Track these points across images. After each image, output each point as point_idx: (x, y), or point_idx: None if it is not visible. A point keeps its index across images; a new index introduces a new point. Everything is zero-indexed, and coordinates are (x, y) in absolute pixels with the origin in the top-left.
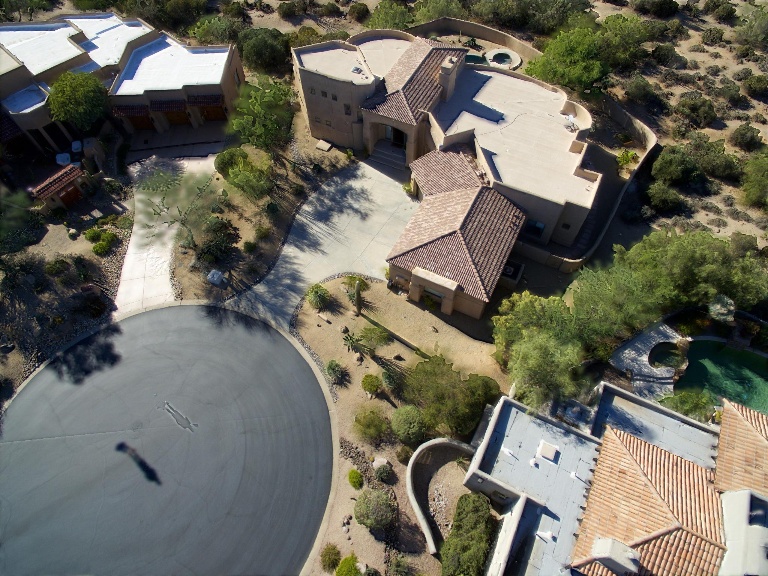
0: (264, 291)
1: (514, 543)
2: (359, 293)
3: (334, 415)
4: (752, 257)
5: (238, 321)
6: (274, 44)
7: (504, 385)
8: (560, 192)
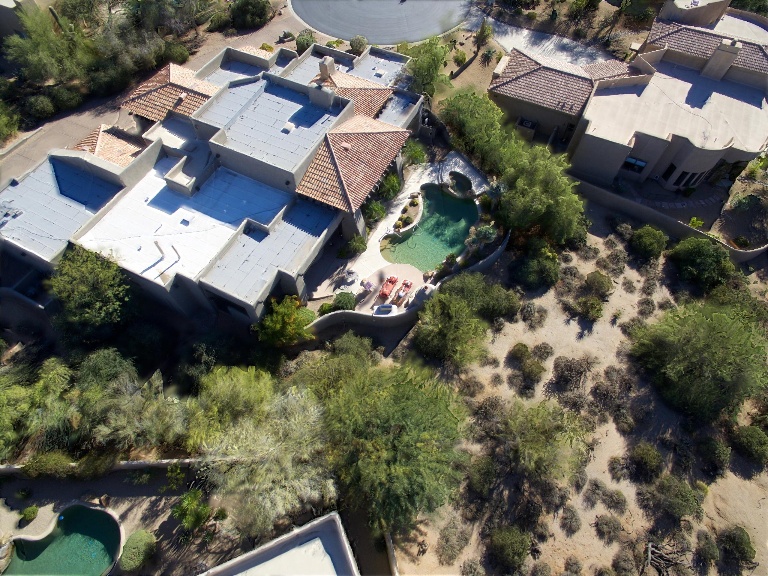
0: (487, 20)
1: (337, 57)
2: (482, 30)
3: (409, 44)
4: (586, 294)
5: (464, 11)
6: (750, 5)
7: (432, 107)
8: (604, 127)
